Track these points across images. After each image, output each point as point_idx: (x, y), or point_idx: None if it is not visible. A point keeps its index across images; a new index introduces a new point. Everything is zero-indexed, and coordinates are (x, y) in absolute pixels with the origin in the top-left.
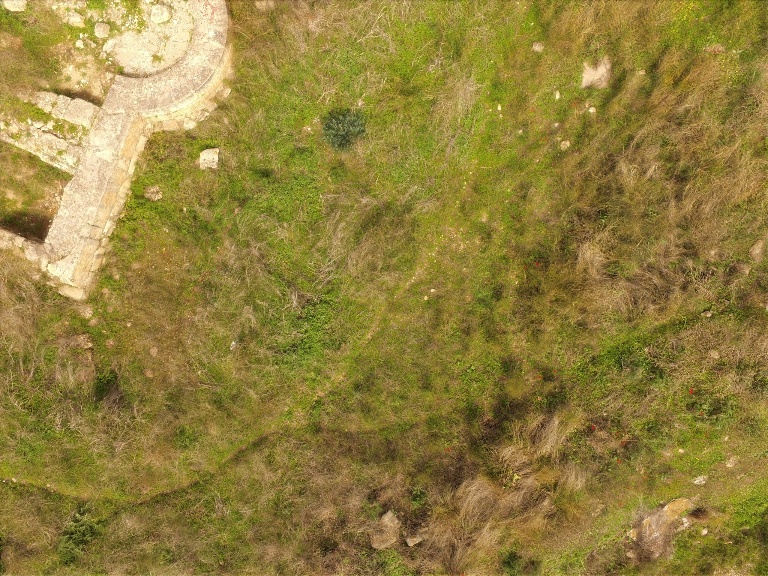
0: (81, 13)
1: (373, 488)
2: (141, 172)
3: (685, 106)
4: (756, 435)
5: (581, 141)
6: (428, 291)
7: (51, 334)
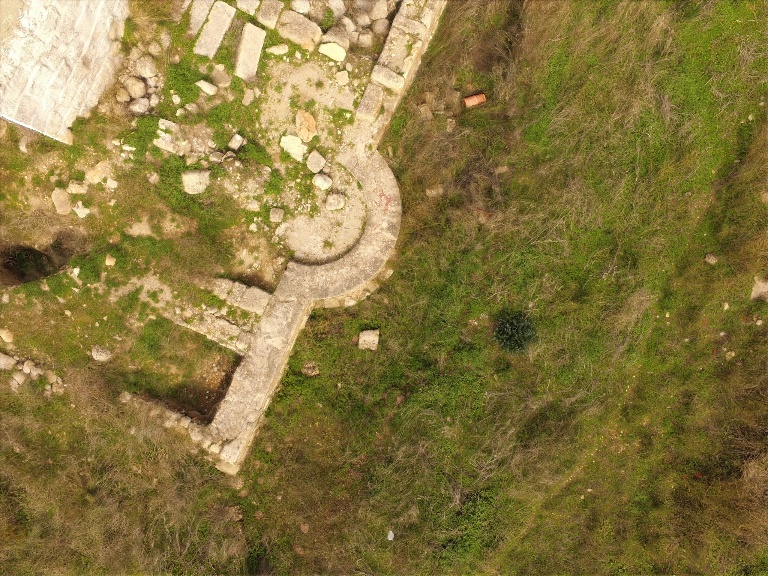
0: (258, 199)
1: None
2: (300, 348)
3: None
4: None
5: (746, 353)
6: (585, 490)
7: (204, 506)
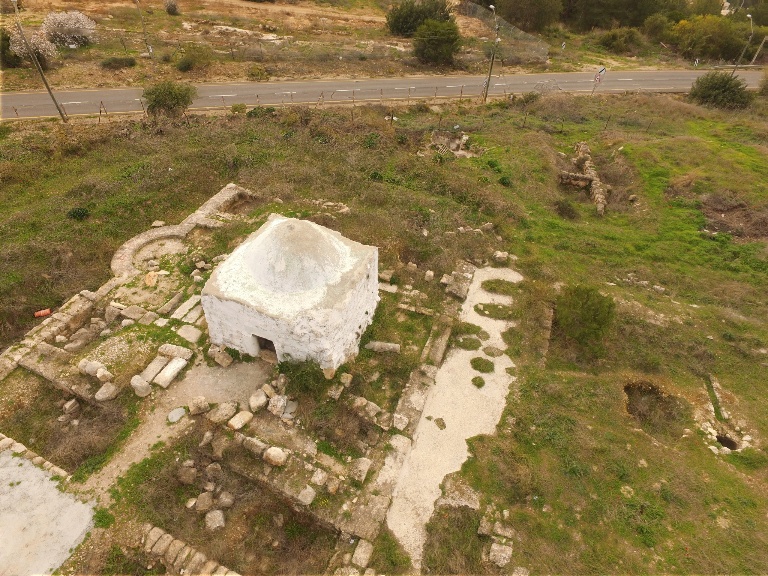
0: None
1: None
2: None
3: None
4: None
5: None
6: None
7: None
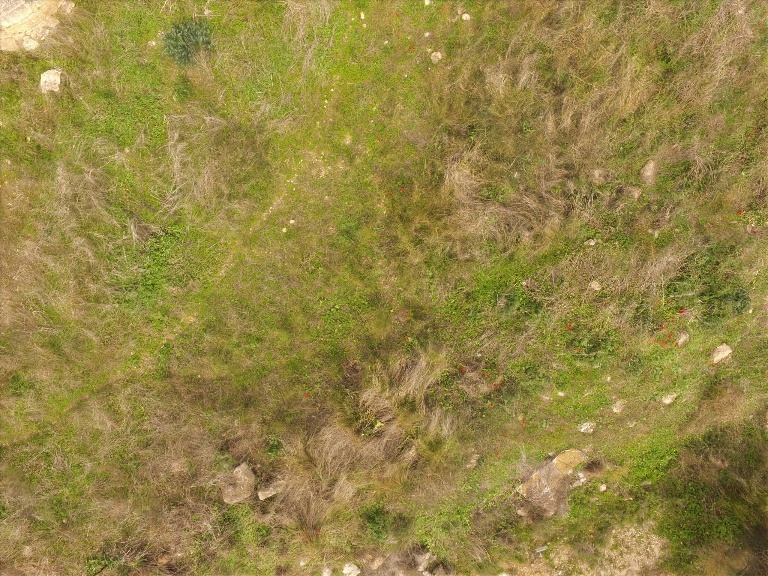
0: None
1: (226, 438)
2: None
3: (564, 8)
4: (638, 373)
5: (453, 53)
6: (287, 222)
7: None
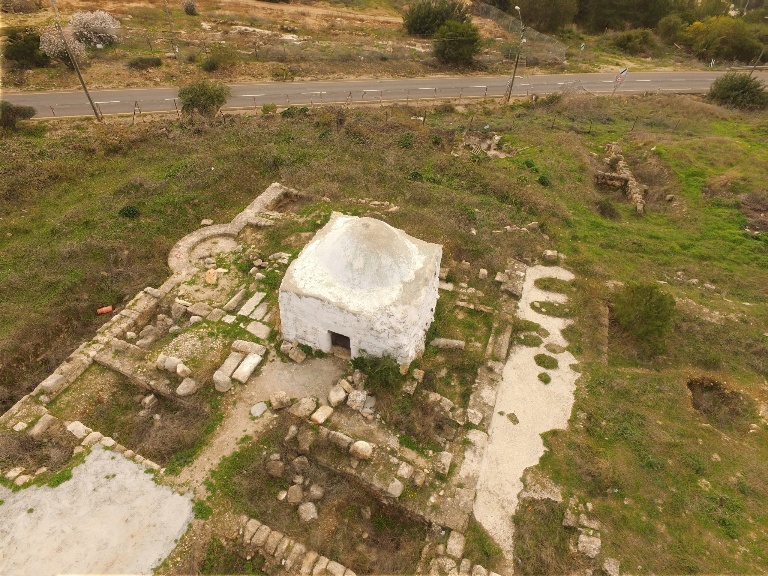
0: None
1: None
2: None
3: None
4: (17, 137)
5: None
6: None
7: None
